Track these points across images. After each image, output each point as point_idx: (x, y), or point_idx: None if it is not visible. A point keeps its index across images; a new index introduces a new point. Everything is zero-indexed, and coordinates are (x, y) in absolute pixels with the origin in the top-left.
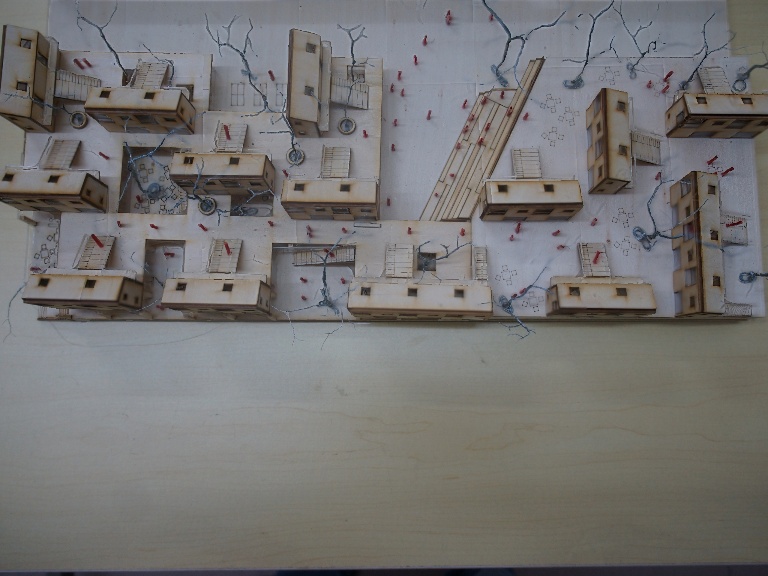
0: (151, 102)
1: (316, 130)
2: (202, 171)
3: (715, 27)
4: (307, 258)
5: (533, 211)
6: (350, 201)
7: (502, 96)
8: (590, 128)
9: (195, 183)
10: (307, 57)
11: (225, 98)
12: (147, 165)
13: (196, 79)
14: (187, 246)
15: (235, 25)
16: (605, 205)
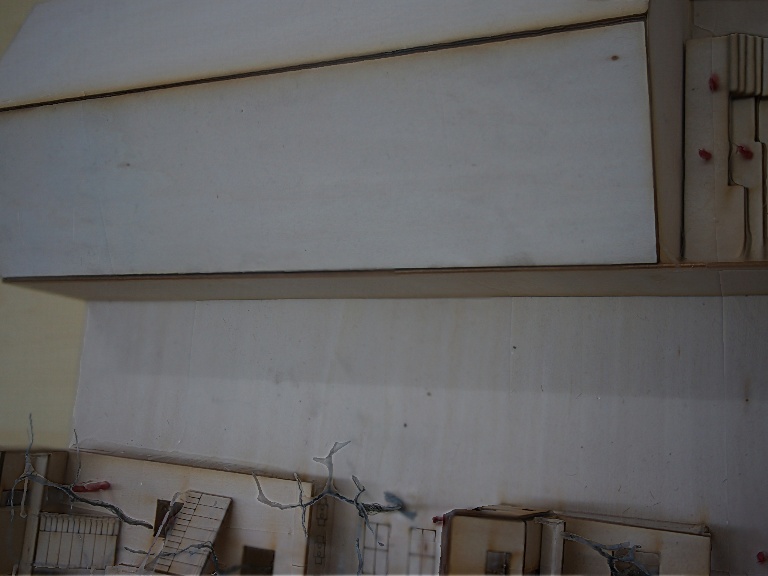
0: None
1: None
2: None
3: None
4: None
5: None
6: None
7: None
8: None
9: None
10: None
11: (351, 554)
12: None
13: (280, 538)
14: None
15: (377, 387)
16: None
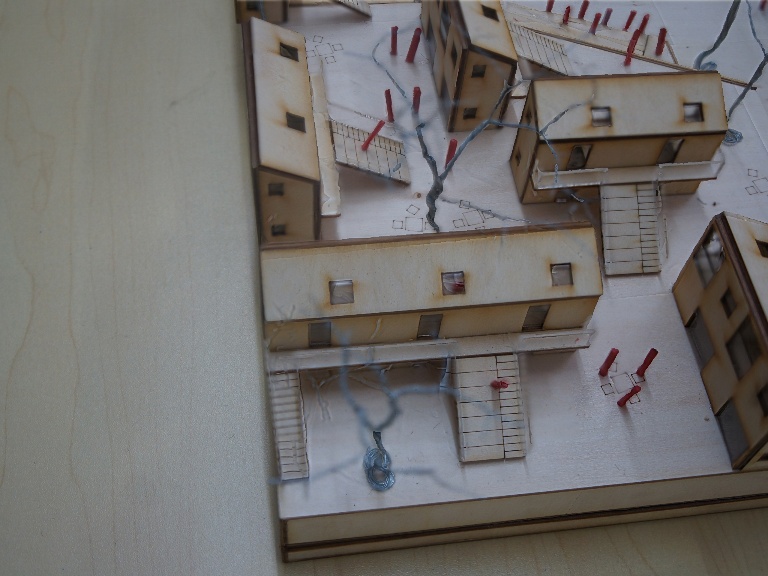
0: None
1: None
2: None
3: None
4: None
5: (442, 9)
6: None
7: (659, 47)
8: None
9: None
10: None
11: None
12: None
13: None
14: None
15: None
16: (493, 187)
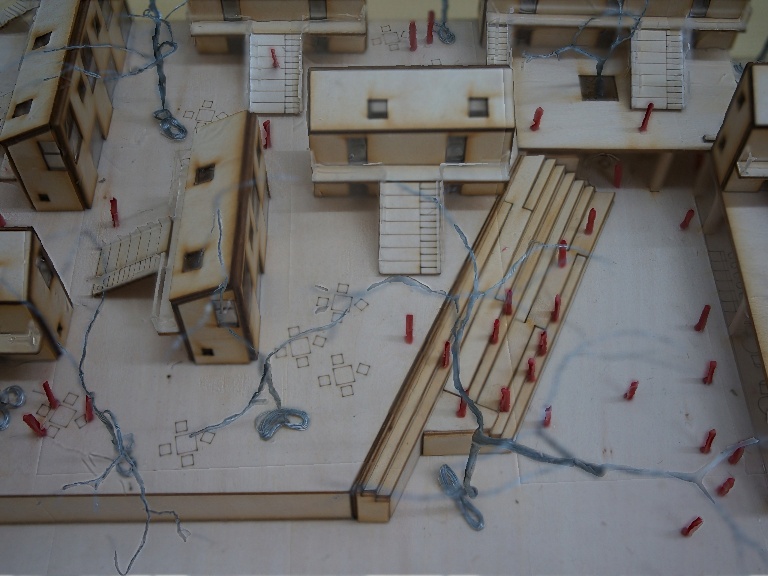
0: None
1: None
2: None
3: None
4: None
5: None
6: None
7: None
8: None
9: None
10: None
11: None
12: None
13: None
14: None
15: None
16: None
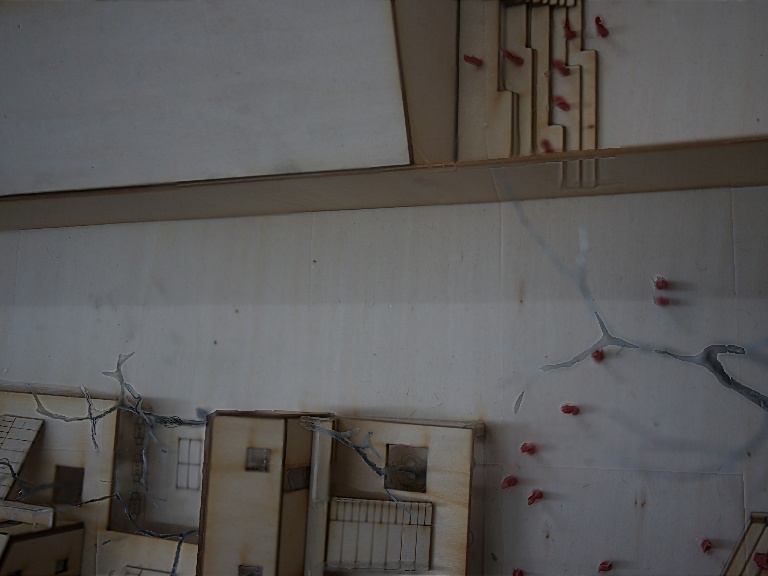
0: None
1: None
2: None
3: None
4: None
5: None
6: None
7: None
8: None
9: None
10: (247, 485)
11: (166, 470)
12: None
13: (89, 456)
14: None
15: (189, 306)
16: None
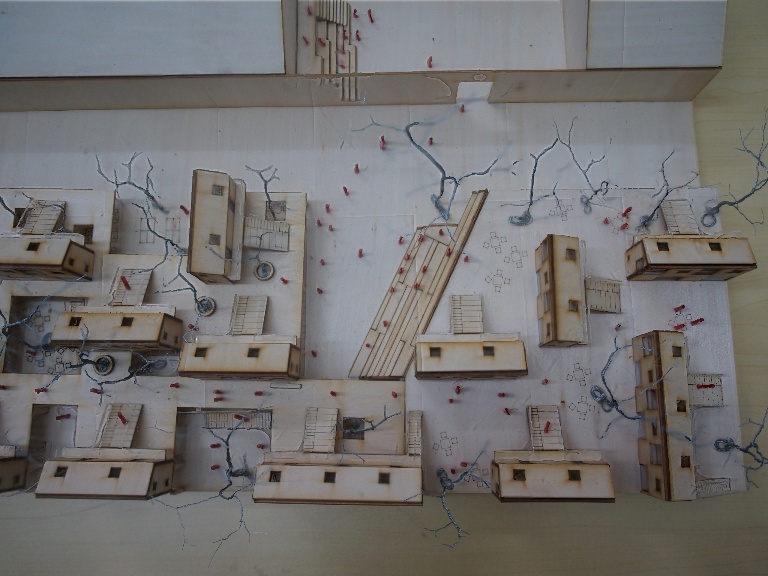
0: (34, 255)
1: (226, 279)
2: (88, 335)
3: (681, 150)
4: (220, 420)
5: (471, 377)
6: (258, 370)
7: (441, 233)
8: (539, 273)
9: (80, 349)
10: (213, 201)
11: (133, 235)
12: (43, 312)
13: (96, 218)
14: (80, 412)
15: (147, 152)
16: (558, 360)
